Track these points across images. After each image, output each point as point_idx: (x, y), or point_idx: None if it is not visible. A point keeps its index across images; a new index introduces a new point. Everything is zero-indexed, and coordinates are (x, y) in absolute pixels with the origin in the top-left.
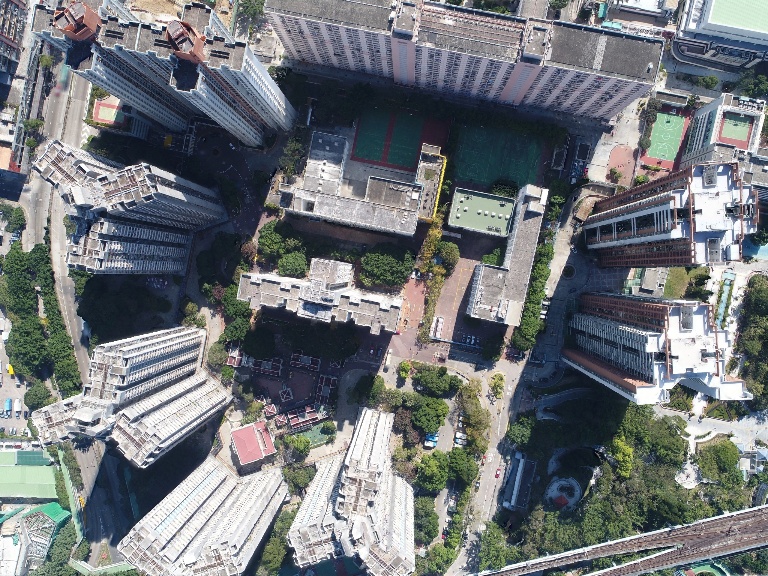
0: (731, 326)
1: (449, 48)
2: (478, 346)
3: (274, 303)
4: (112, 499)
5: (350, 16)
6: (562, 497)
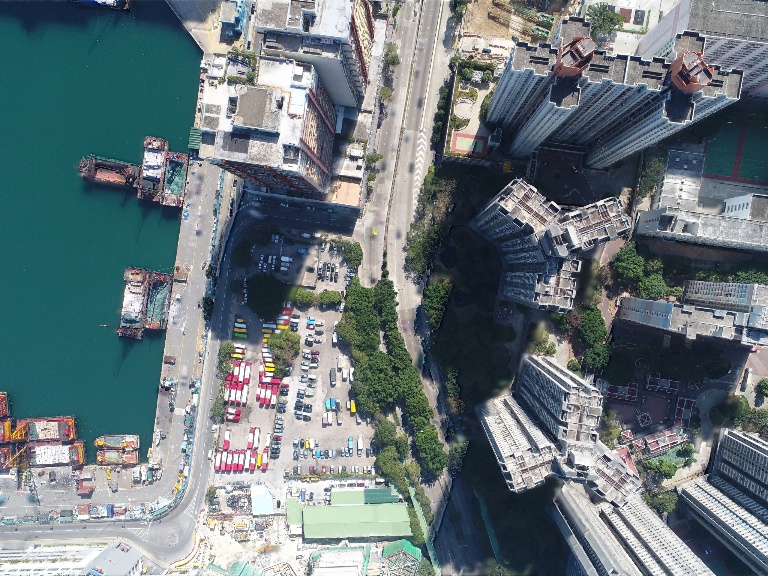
0: None
1: None
2: None
3: (707, 331)
4: (461, 533)
5: None
6: None
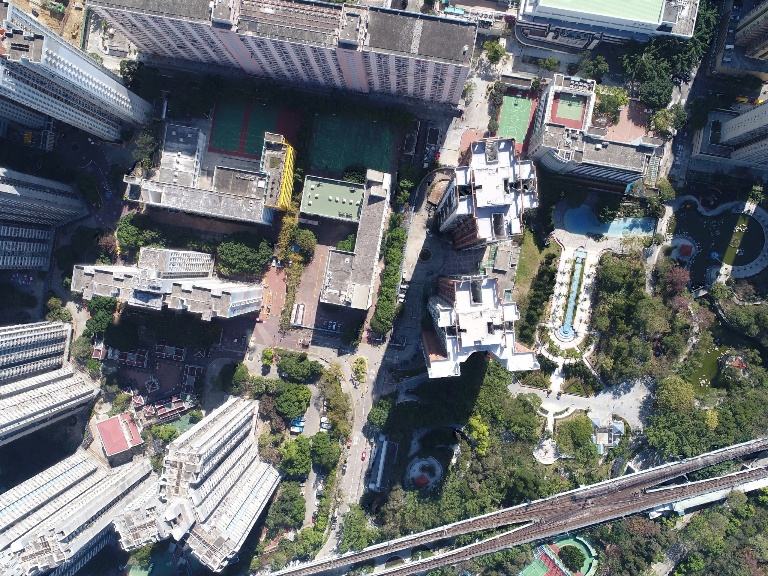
0: (584, 303)
1: (270, 36)
2: (339, 331)
3: (108, 293)
4: None
5: (172, 7)
6: (422, 477)
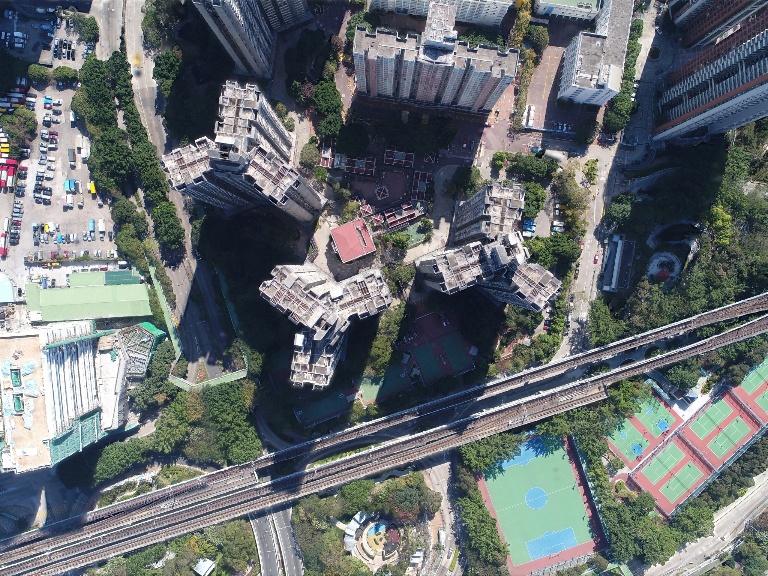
0: None
1: None
2: (571, 132)
3: (391, 55)
4: (207, 316)
5: None
6: (664, 271)
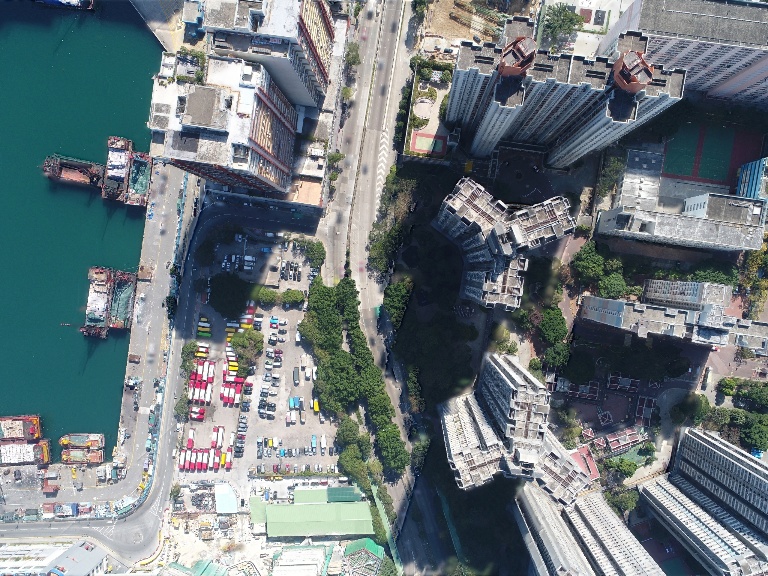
0: None
1: None
2: None
3: (658, 330)
4: (424, 532)
5: (727, 33)
6: None
